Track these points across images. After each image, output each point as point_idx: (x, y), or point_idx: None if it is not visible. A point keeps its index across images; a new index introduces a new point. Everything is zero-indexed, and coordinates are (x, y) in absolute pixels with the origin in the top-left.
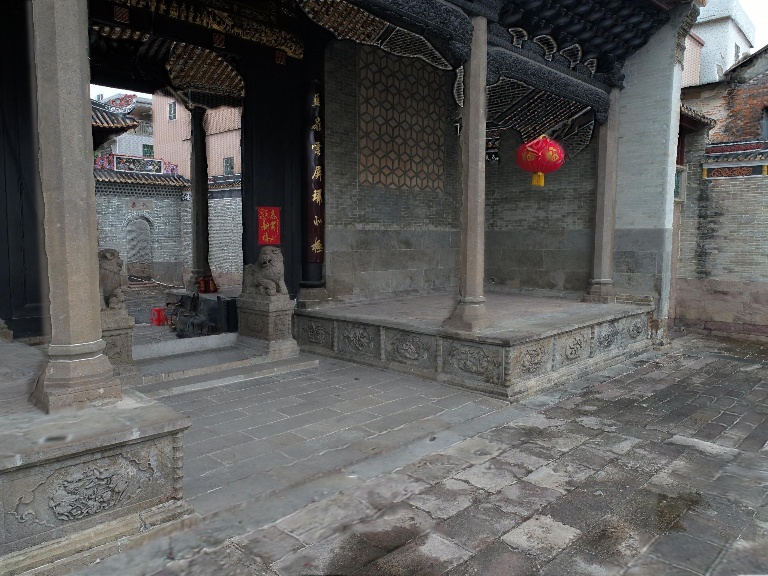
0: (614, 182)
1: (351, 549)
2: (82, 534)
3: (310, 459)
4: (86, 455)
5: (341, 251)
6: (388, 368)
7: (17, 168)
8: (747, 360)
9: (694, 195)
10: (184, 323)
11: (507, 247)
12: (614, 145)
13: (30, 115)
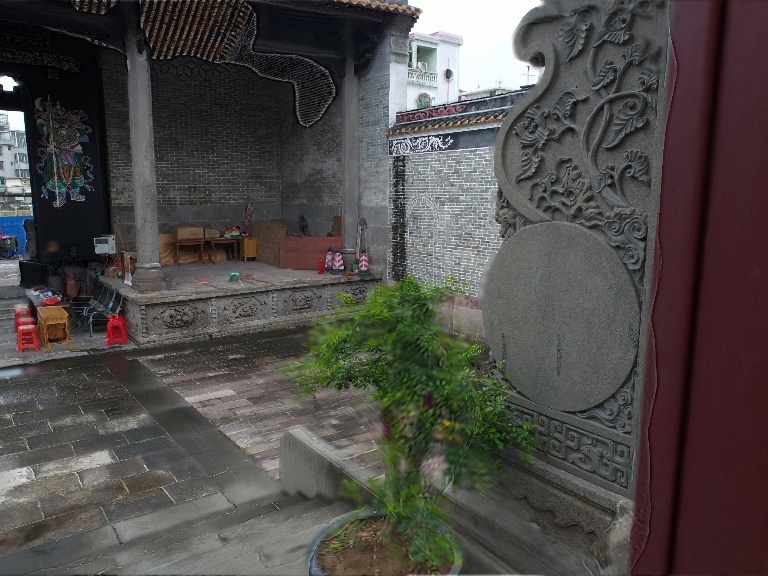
0: None
1: None
2: None
3: (5, 281)
4: None
5: None
6: None
7: None
8: None
9: None
10: None
11: None
12: None
13: None
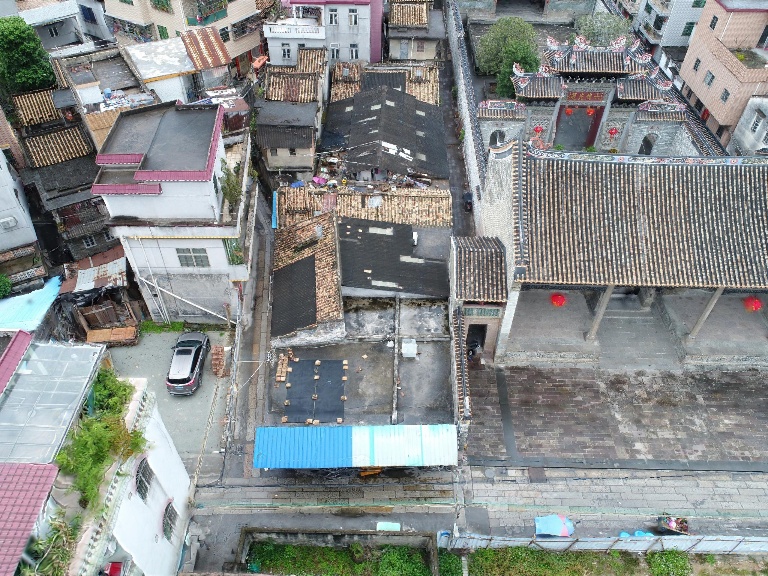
0: None
1: (615, 380)
2: (585, 360)
3: None
4: None
5: None
6: (668, 332)
7: None
8: None
9: None
10: None
11: (767, 296)
12: None
13: None
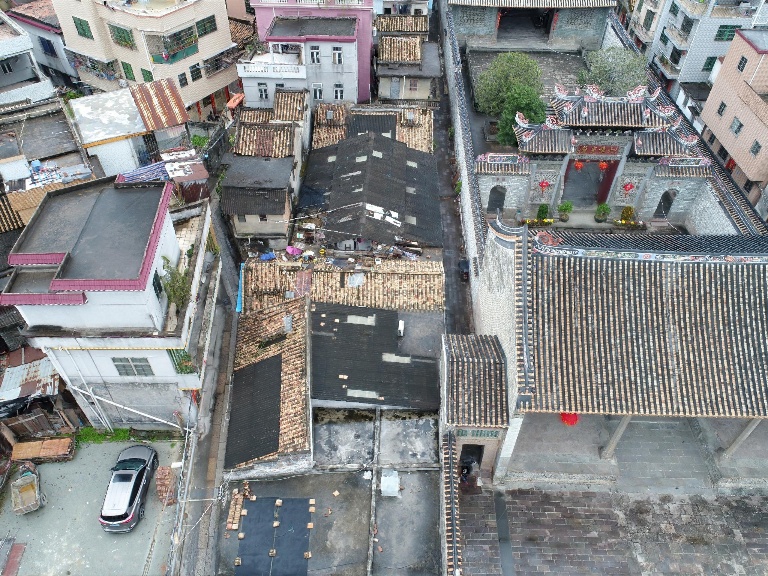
0: None
1: (636, 509)
2: (600, 481)
3: None
4: None
5: None
6: (697, 443)
7: None
8: None
9: None
10: None
11: None
12: None
13: None
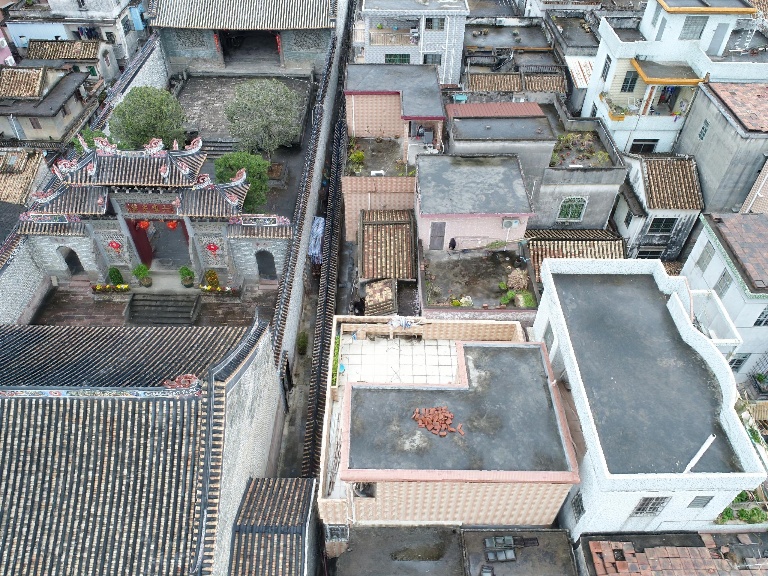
0: None
1: None
2: None
3: None
4: None
5: None
6: None
7: None
8: None
9: None
10: None
11: None
12: None
13: None
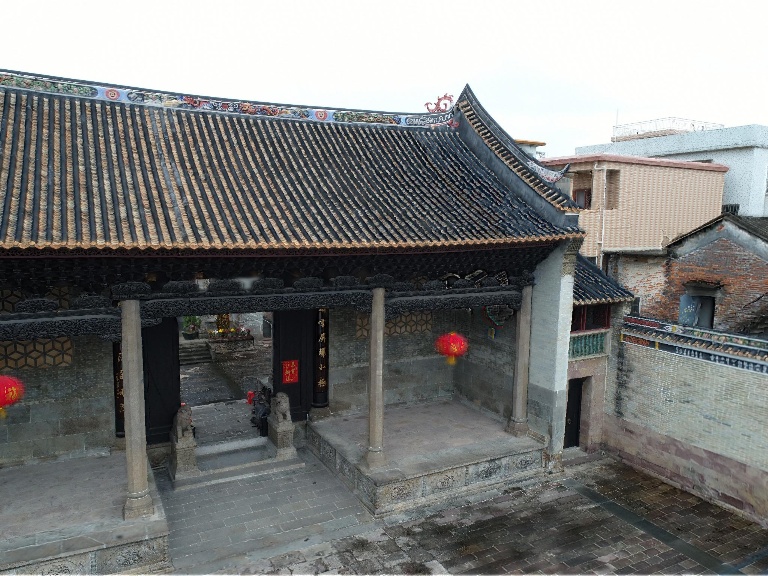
0: (526, 351)
1: None
2: (127, 571)
3: (238, 544)
4: (129, 544)
5: (341, 383)
6: (337, 476)
7: (146, 363)
8: (598, 498)
9: (615, 352)
10: (257, 411)
11: (475, 375)
12: (526, 326)
13: (153, 335)
